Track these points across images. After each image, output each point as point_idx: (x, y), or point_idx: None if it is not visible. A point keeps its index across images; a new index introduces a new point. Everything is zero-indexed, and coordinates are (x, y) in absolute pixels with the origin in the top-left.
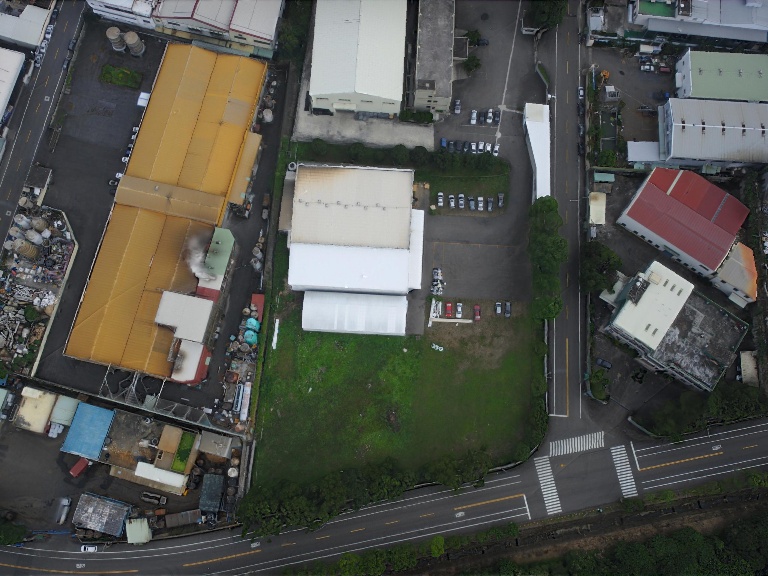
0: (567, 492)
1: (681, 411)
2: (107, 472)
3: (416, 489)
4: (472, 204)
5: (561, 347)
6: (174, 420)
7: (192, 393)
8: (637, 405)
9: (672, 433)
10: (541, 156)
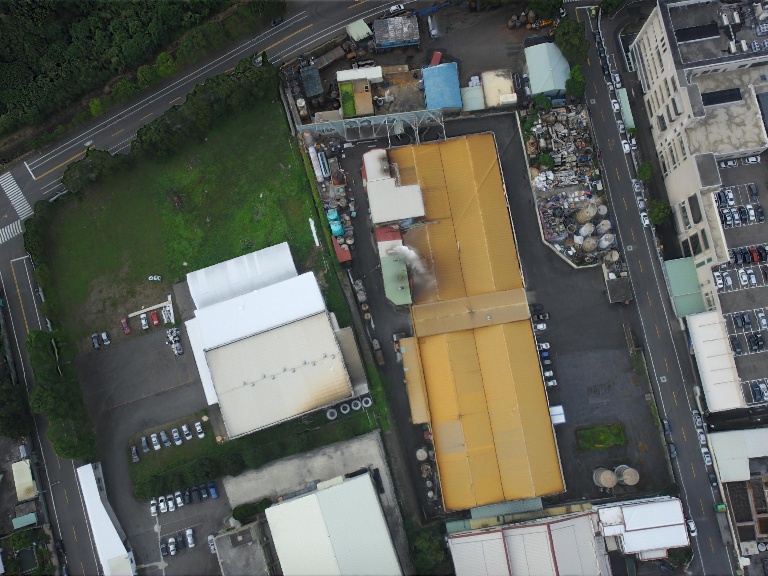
0: None
1: None
2: None
3: None
4: (164, 437)
5: (33, 323)
6: None
7: None
8: None
9: None
10: (99, 517)
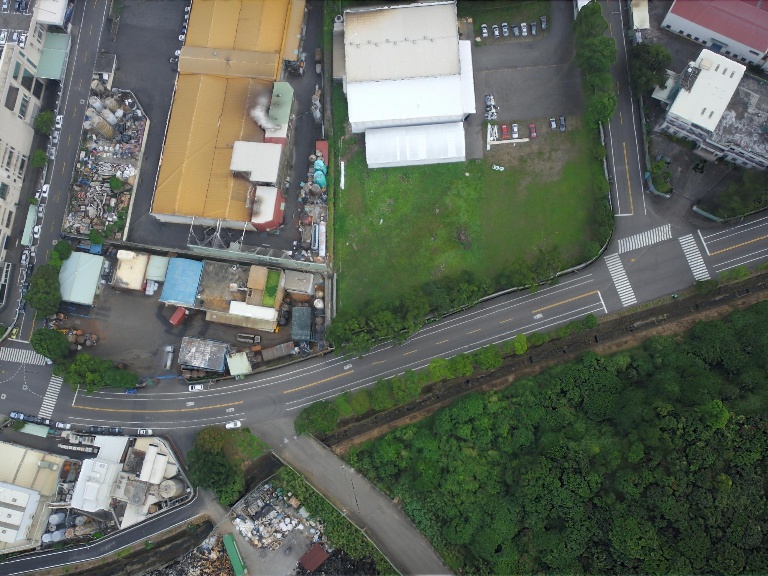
0: (640, 284)
1: (745, 188)
2: (203, 320)
3: (493, 299)
4: (516, 30)
5: (619, 151)
6: (258, 263)
7: (271, 239)
8: (700, 195)
9: (739, 208)
10: None
